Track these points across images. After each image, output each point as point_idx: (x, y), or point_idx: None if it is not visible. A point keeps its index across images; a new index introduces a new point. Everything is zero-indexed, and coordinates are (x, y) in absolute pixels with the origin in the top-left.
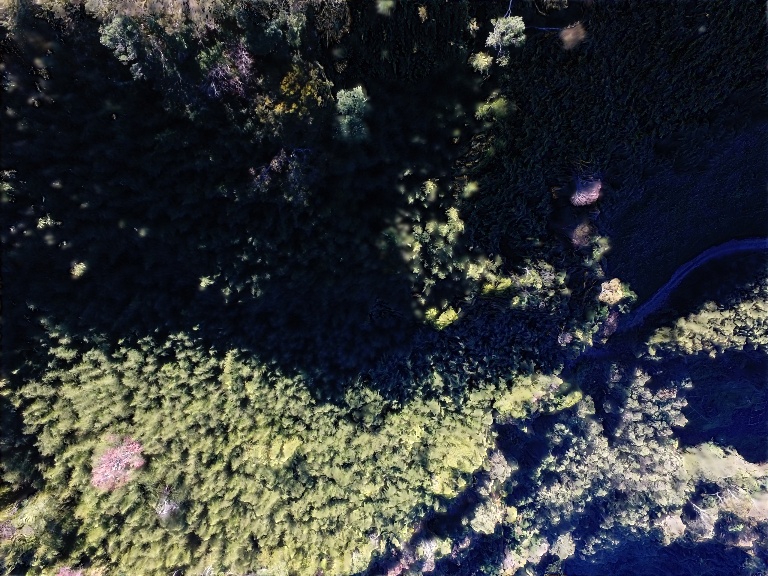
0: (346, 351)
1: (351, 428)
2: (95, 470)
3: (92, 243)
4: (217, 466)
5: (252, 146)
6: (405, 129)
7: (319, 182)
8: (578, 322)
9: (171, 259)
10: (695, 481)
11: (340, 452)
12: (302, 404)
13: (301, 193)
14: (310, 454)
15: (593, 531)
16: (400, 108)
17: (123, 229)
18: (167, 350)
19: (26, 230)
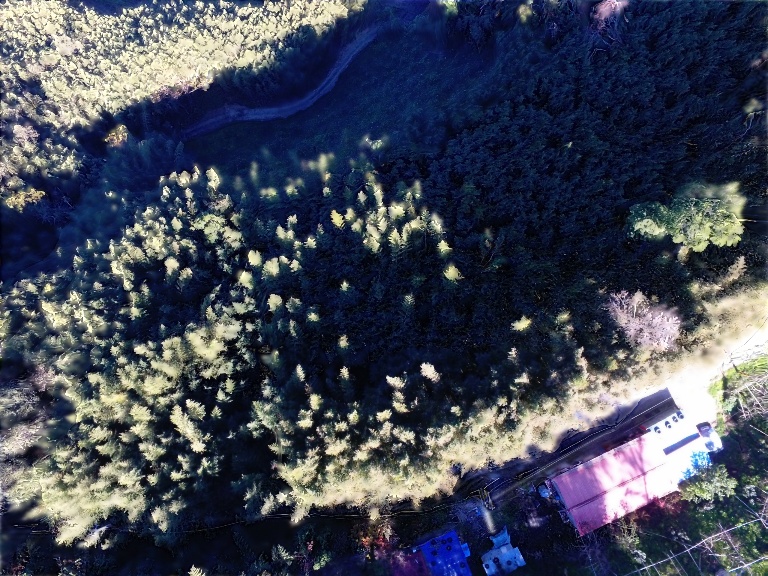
0: None
1: None
2: None
3: None
4: None
5: None
6: None
7: None
8: None
9: None
10: None
11: None
12: None
13: None
14: None
15: None
16: None
17: None
18: None
19: None
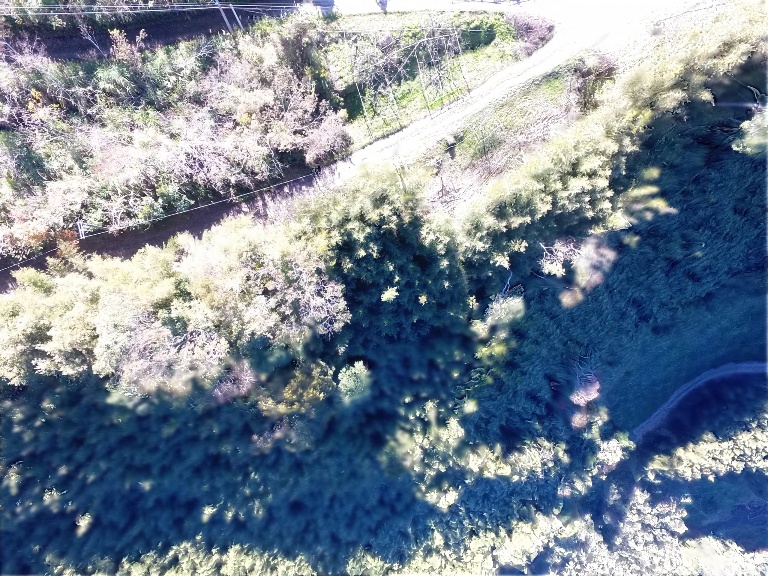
0: (347, 526)
1: None
2: None
3: (97, 497)
4: None
5: (255, 420)
6: (406, 369)
7: (321, 425)
8: (577, 472)
9: (174, 493)
10: (695, 575)
11: None
12: None
13: (303, 437)
14: None
15: None
16: (401, 357)
17: (127, 485)
18: (170, 556)
19: (32, 502)
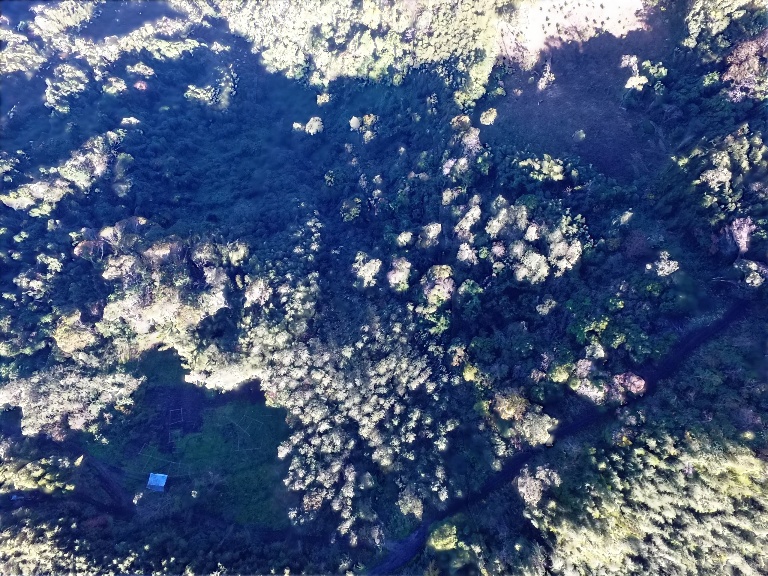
0: None
1: None
2: None
3: None
4: None
5: None
6: None
7: None
8: None
9: None
10: None
11: None
12: None
13: None
14: None
15: None
16: None
17: None
18: None
19: None
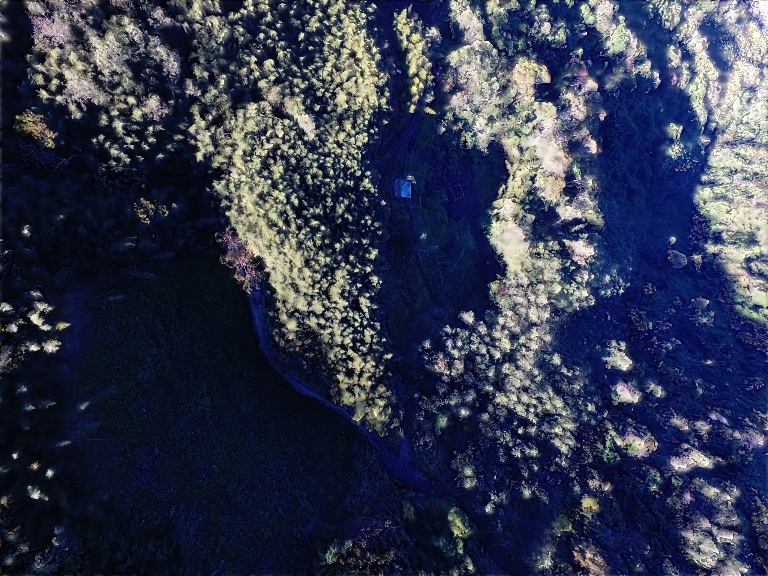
0: None
1: None
2: None
3: None
4: None
5: None
6: None
7: None
8: None
9: None
10: (532, 249)
11: None
12: None
13: None
14: None
15: None
16: None
17: None
18: None
19: None
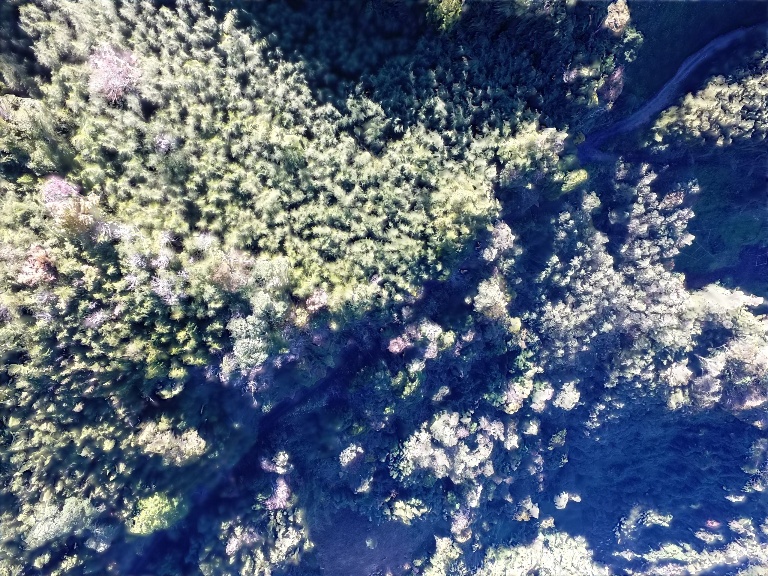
0: (348, 48)
1: (353, 139)
2: (92, 97)
3: None
4: (216, 138)
5: None
6: None
7: None
8: (583, 62)
9: None
10: (701, 321)
11: (341, 163)
12: (303, 97)
13: None
14: (311, 161)
15: (598, 398)
16: None
17: None
18: None
19: None
